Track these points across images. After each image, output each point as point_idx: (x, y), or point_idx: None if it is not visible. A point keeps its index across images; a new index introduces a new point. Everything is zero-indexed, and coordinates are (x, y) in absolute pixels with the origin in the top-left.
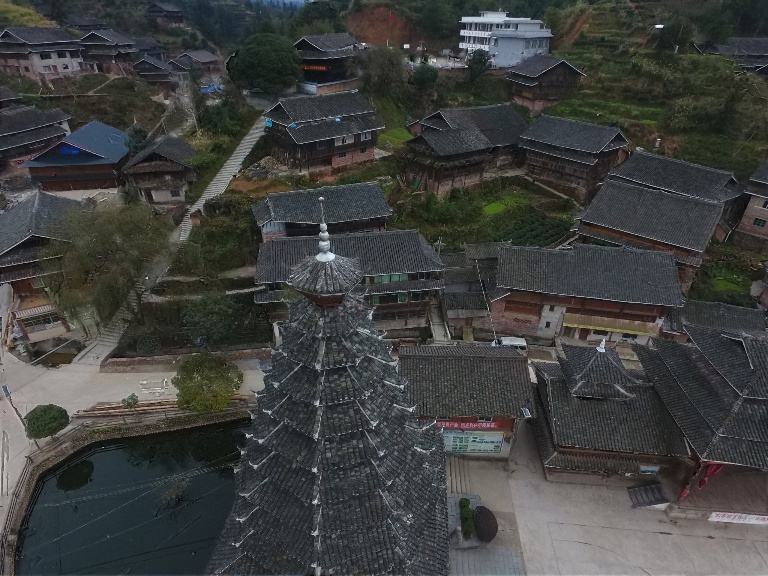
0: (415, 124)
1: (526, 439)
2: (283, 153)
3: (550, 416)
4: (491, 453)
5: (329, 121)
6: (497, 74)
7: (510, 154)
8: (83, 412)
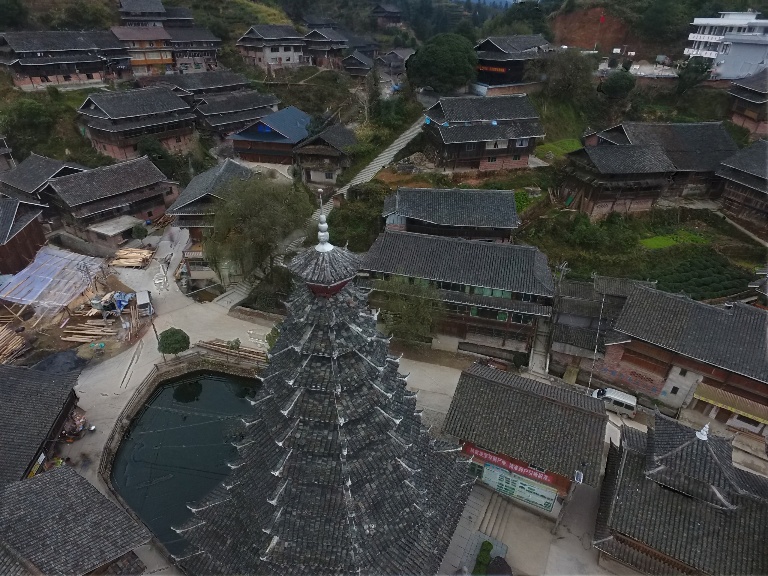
0: (592, 136)
1: (593, 509)
2: (434, 151)
3: (615, 492)
4: (541, 508)
5: (485, 124)
6: (718, 87)
7: (700, 182)
8: (203, 343)
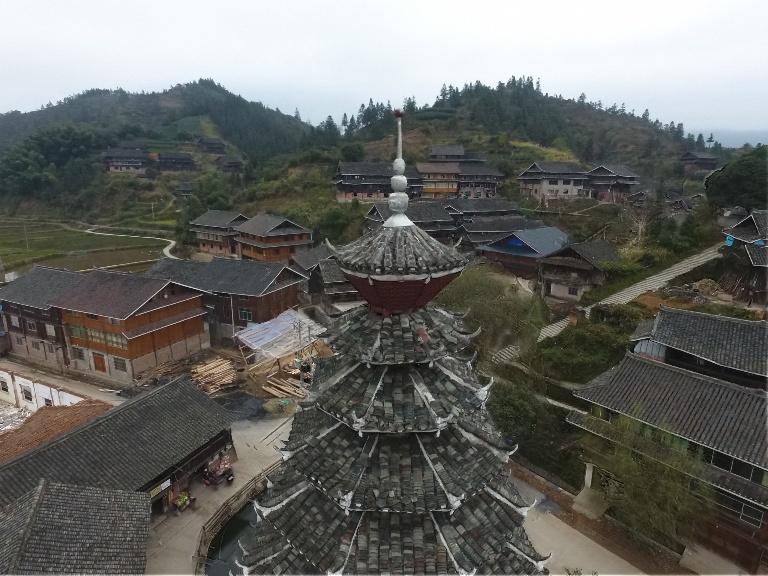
0: None
1: None
2: (734, 279)
3: None
4: None
5: None
6: None
7: None
8: None
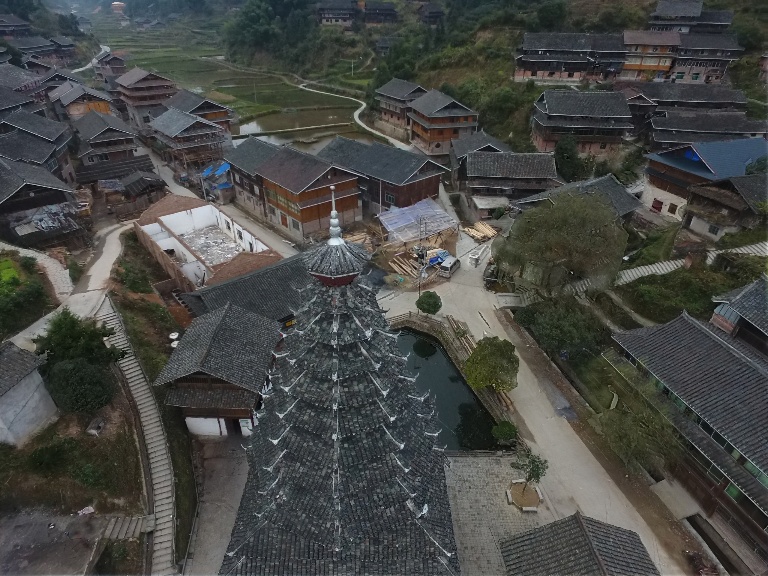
0: None
1: None
2: None
3: None
4: None
5: None
6: None
7: None
8: (452, 318)
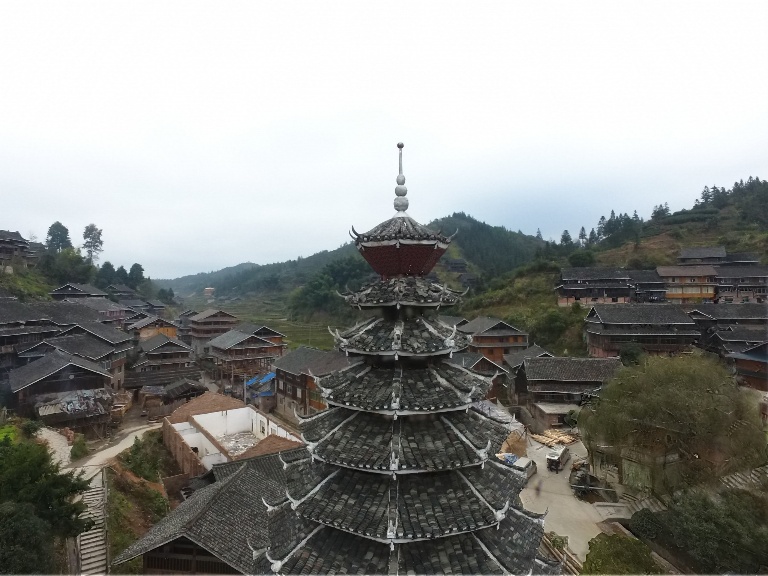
0: None
1: None
2: None
3: None
4: None
5: None
6: None
7: None
8: None
